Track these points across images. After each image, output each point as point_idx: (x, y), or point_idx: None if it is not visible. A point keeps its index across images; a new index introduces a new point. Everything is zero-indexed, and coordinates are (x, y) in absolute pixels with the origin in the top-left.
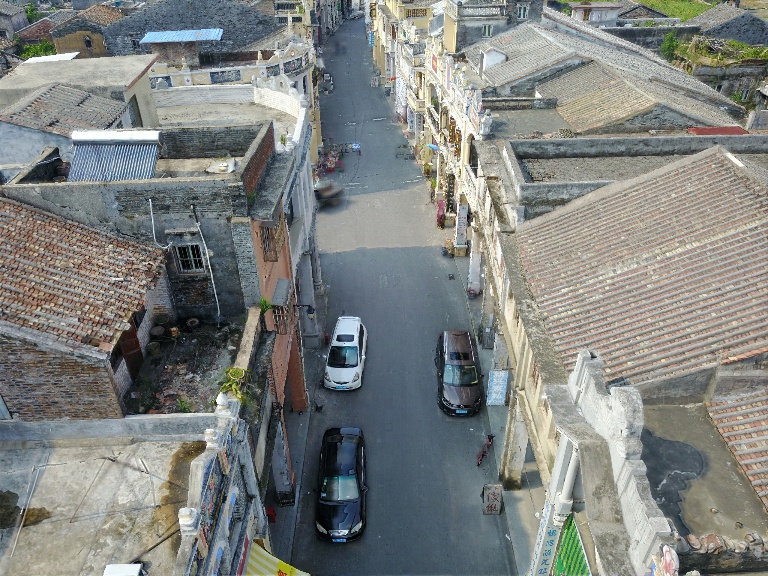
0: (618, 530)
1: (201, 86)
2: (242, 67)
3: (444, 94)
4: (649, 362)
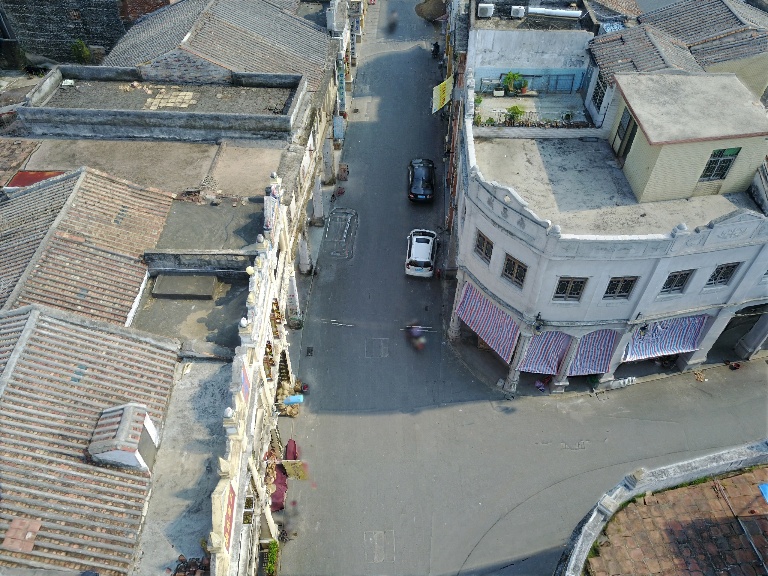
0: None
1: (629, 236)
2: (670, 466)
3: None
4: None
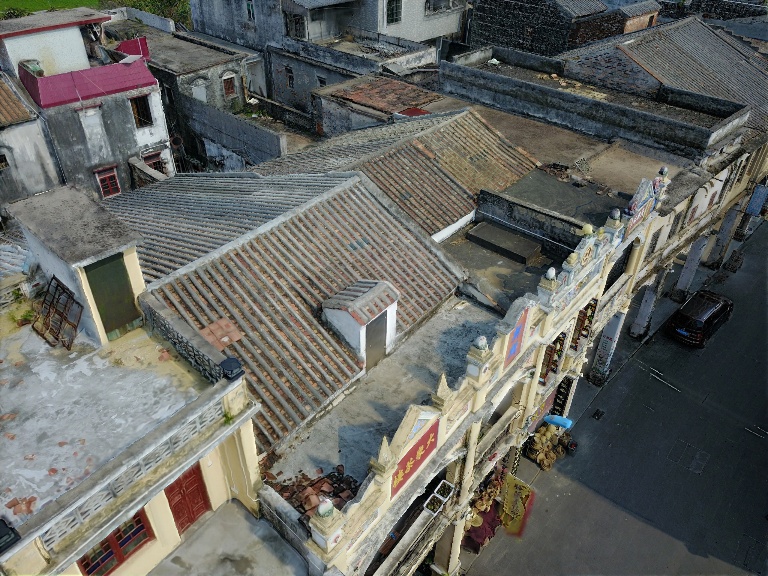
0: None
1: None
2: None
3: (492, 398)
4: (766, 79)
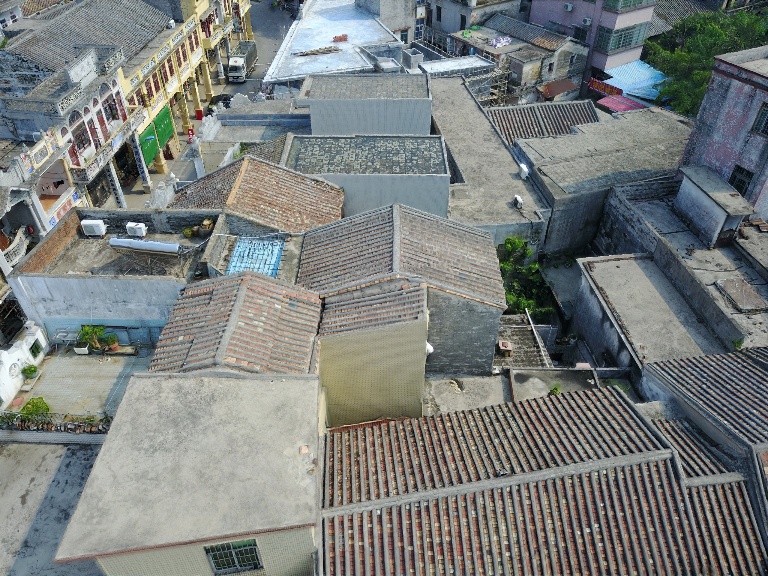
0: (22, 185)
1: None
2: None
3: None
4: None
